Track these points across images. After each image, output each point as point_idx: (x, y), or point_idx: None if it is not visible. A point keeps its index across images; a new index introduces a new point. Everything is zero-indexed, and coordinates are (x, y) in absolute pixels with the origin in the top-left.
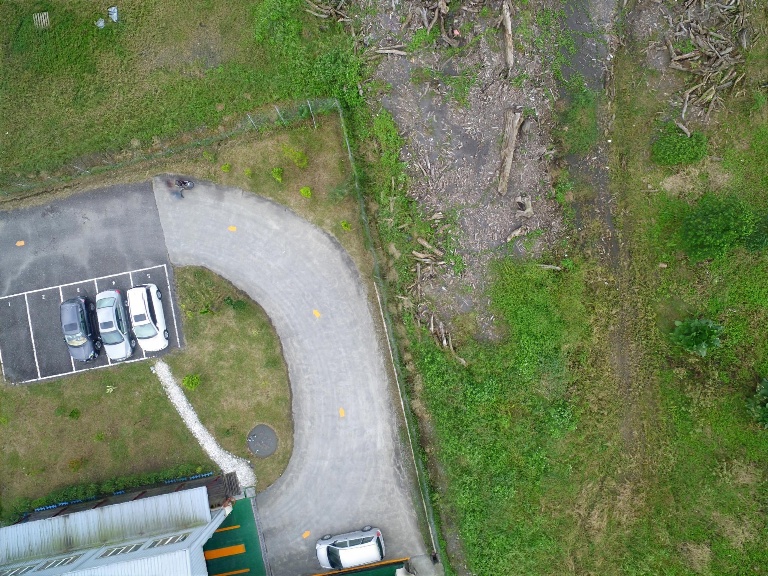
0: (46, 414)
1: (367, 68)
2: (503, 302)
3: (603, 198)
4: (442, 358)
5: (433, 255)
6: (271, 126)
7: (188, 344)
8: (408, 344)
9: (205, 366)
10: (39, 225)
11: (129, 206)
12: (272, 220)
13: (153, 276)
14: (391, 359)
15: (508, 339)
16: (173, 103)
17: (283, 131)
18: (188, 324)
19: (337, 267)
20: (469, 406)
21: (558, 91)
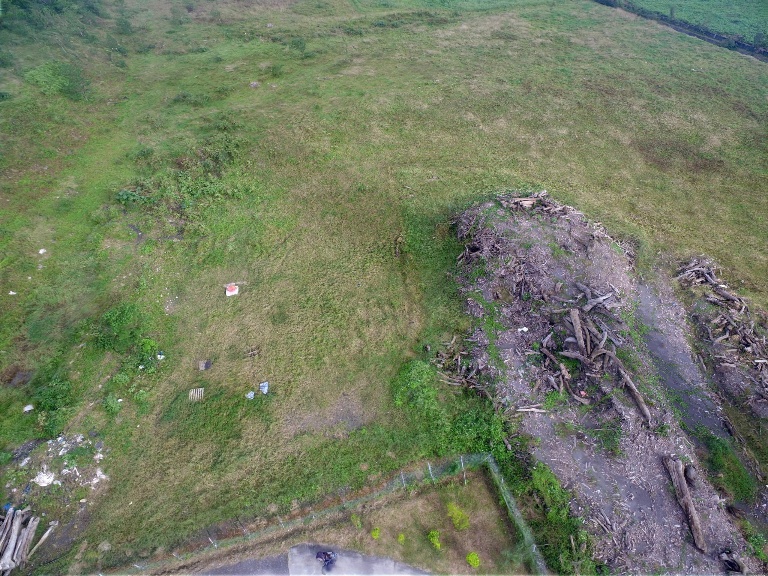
0: None
1: (512, 425)
2: None
3: None
4: None
5: None
6: (419, 484)
7: None
8: None
9: None
10: None
11: None
12: None
13: None
14: None
15: None
16: (317, 464)
17: (431, 489)
18: None
19: None
20: None
21: (691, 440)
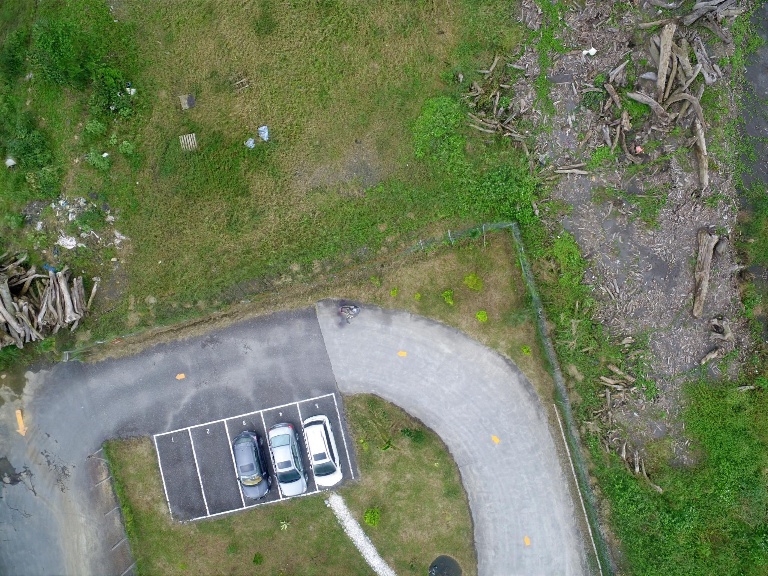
0: (217, 552)
1: (545, 188)
2: (699, 427)
3: None
4: (637, 486)
5: (624, 381)
6: (437, 246)
7: (362, 475)
8: (593, 468)
9: (381, 497)
10: (199, 357)
11: (292, 334)
12: (443, 344)
13: (322, 406)
14: (575, 483)
15: (704, 464)
16: (334, 226)
17: (449, 250)
18: (361, 454)
19: (515, 390)
20: (668, 535)
21: (739, 200)
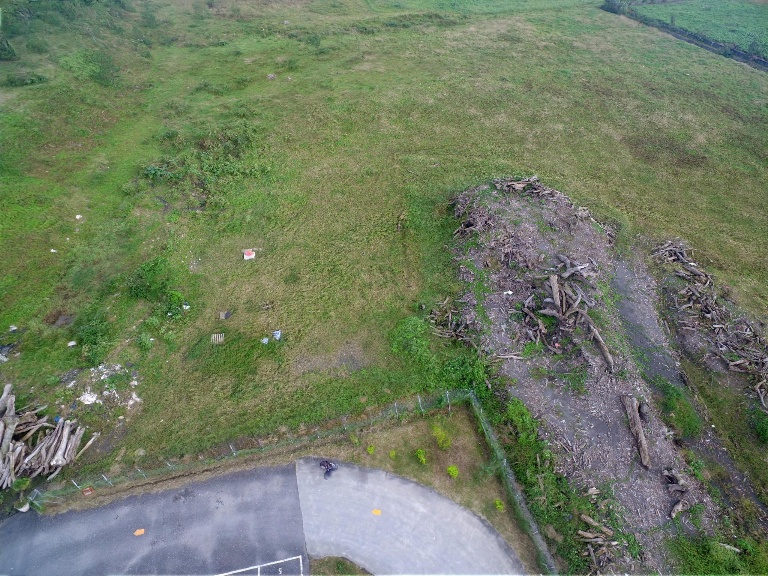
0: None
1: (493, 368)
2: None
3: (737, 477)
4: None
5: (602, 534)
6: (410, 414)
7: None
8: None
9: None
10: (167, 511)
11: (269, 489)
12: (418, 502)
13: (285, 571)
14: None
15: None
16: (322, 396)
17: (421, 419)
18: None
19: (496, 555)
20: None
21: (650, 387)
